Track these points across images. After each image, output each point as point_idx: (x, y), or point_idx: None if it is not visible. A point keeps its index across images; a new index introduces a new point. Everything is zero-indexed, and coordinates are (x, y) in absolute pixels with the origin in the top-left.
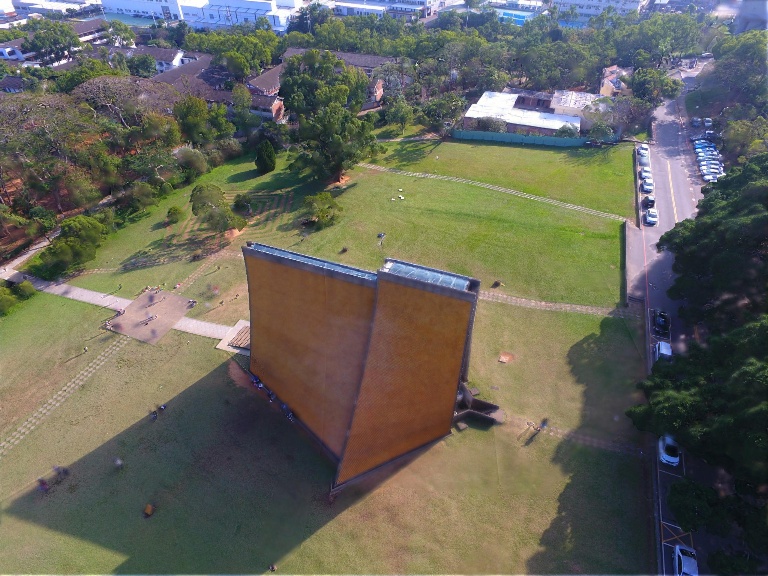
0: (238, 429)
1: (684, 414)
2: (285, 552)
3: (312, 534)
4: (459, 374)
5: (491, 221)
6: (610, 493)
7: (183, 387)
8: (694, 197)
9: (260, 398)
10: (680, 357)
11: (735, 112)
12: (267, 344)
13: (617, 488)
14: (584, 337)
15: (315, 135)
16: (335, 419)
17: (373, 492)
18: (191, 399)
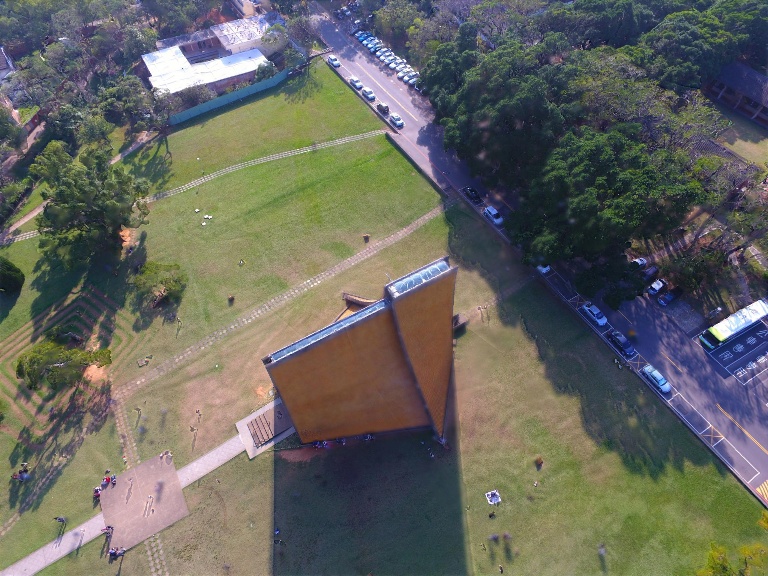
0: (349, 480)
1: (558, 246)
2: (462, 495)
3: (462, 472)
4: (452, 316)
5: (305, 190)
6: (541, 308)
7: (270, 506)
8: (400, 87)
9: (335, 450)
10: (513, 213)
11: (368, 1)
12: (313, 413)
13: (541, 303)
14: (448, 234)
15: (77, 215)
16: (404, 408)
17: (459, 420)
18: (289, 504)
